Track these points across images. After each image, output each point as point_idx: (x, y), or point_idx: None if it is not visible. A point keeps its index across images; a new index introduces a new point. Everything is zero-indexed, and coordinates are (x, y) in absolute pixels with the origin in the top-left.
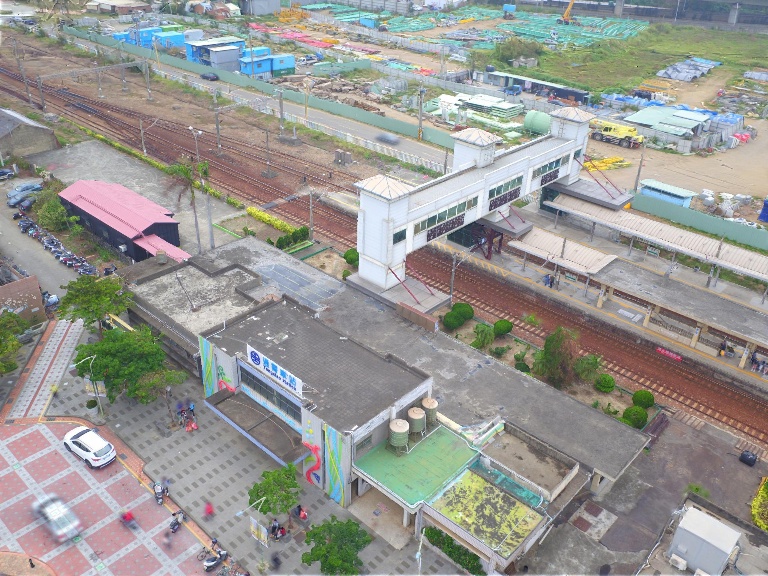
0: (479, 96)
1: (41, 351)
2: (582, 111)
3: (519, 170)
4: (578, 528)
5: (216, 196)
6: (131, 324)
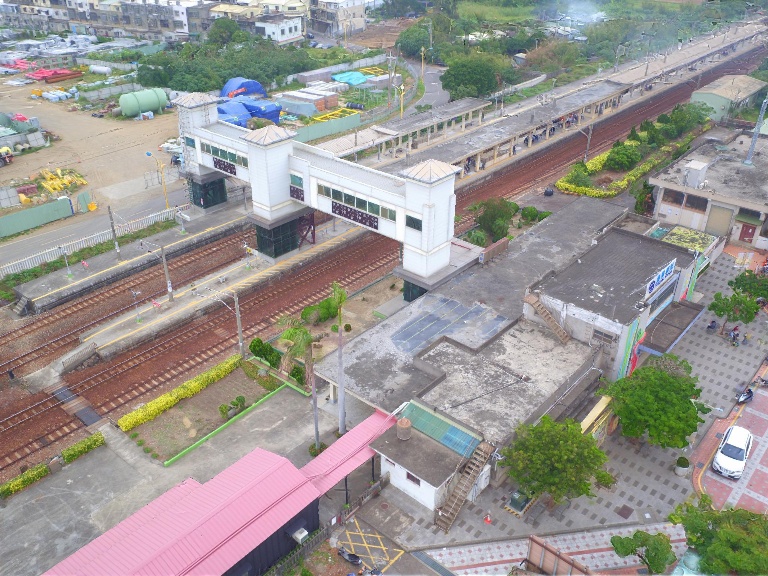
0: None
1: (596, 572)
2: None
3: None
4: None
5: (33, 480)
6: (503, 485)
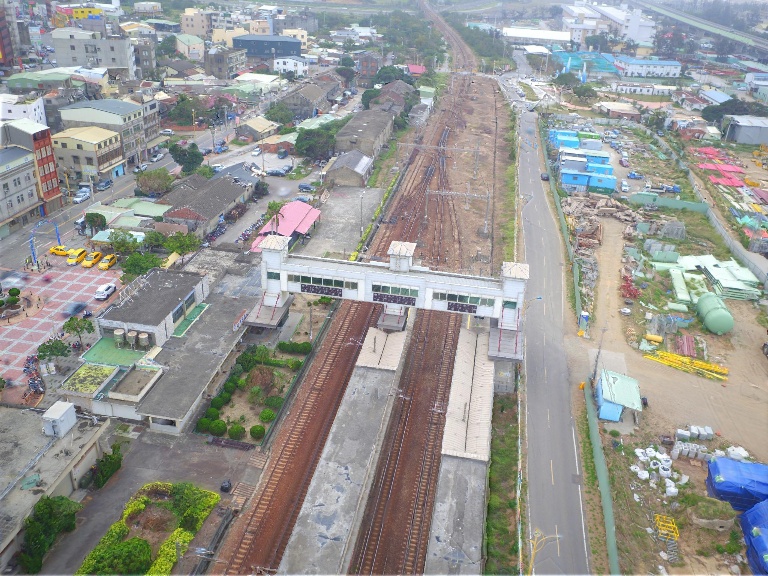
0: (737, 269)
1: None
2: (519, 269)
3: (412, 284)
4: (120, 426)
5: None
6: None
